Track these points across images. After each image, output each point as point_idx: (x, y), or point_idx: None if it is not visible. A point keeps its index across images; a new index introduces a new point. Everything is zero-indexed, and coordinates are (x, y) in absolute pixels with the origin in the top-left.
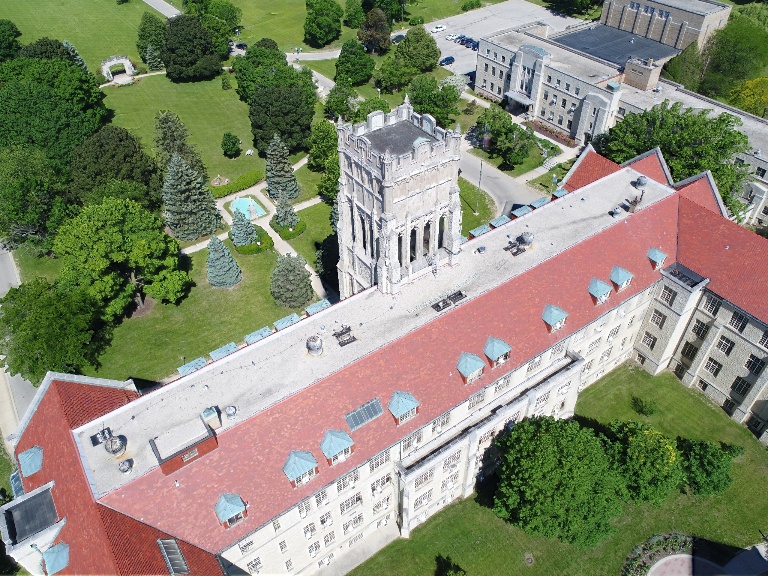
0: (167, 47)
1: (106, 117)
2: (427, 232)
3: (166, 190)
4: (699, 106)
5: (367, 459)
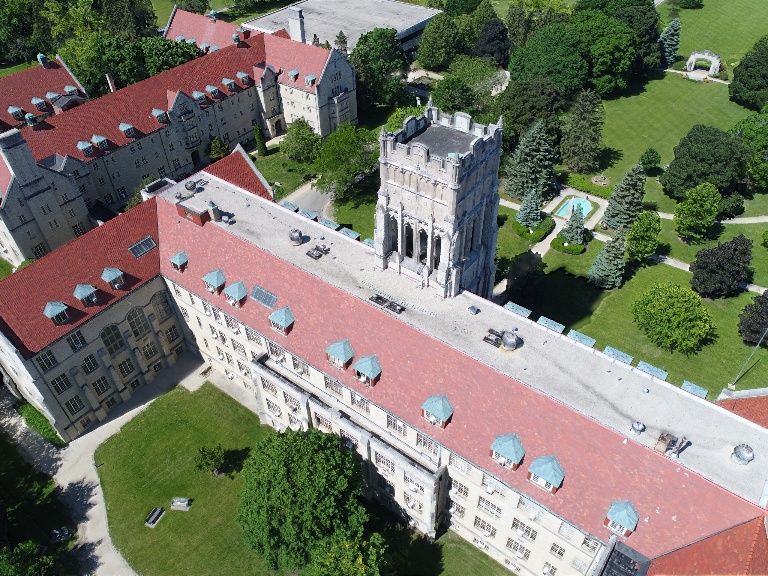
0: (745, 61)
1: (631, 92)
2: (426, 242)
3: (521, 145)
4: None
5: (242, 321)
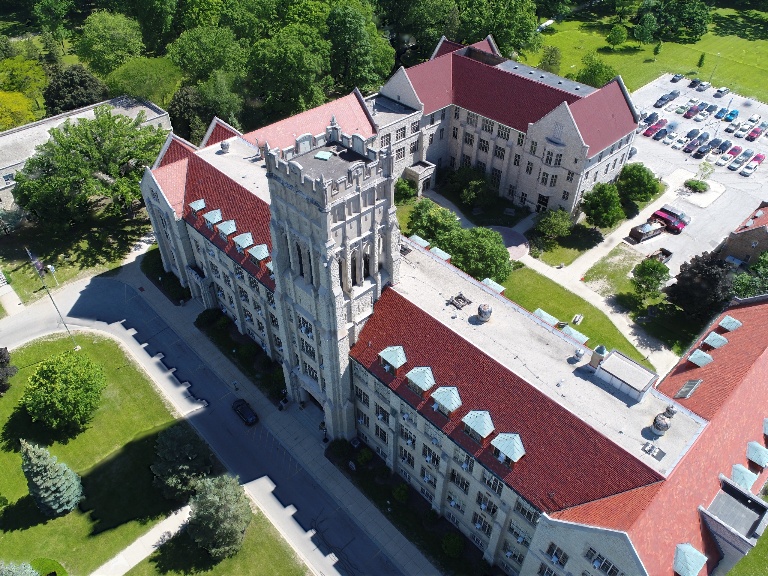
0: None
1: None
2: None
3: None
4: (6, 142)
5: None
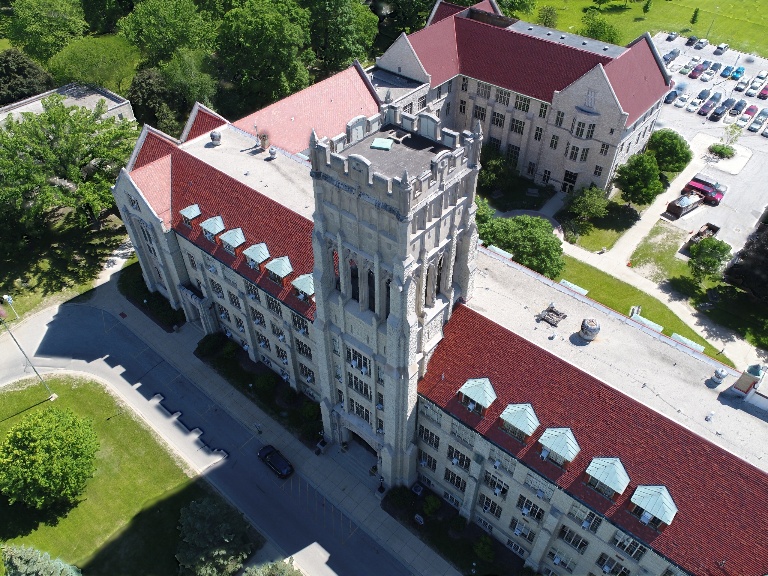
0: None
1: None
2: None
3: None
4: None
5: None
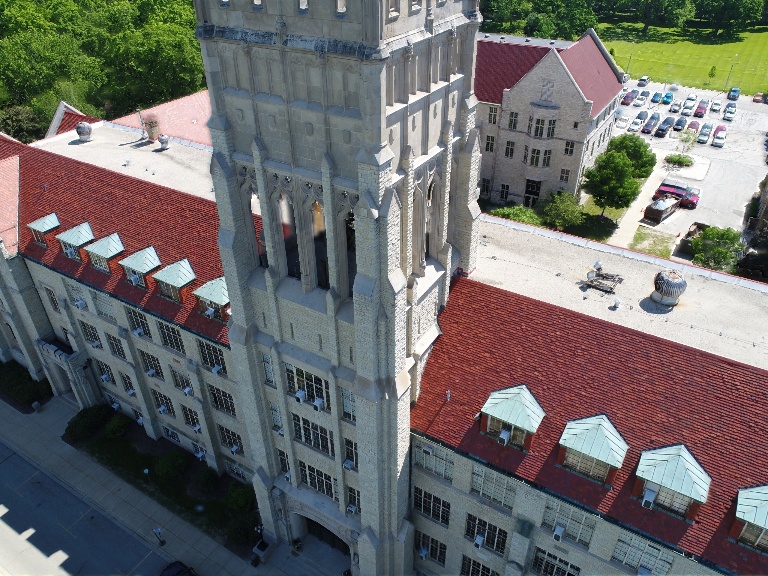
0: None
1: None
2: None
3: None
4: None
5: None
